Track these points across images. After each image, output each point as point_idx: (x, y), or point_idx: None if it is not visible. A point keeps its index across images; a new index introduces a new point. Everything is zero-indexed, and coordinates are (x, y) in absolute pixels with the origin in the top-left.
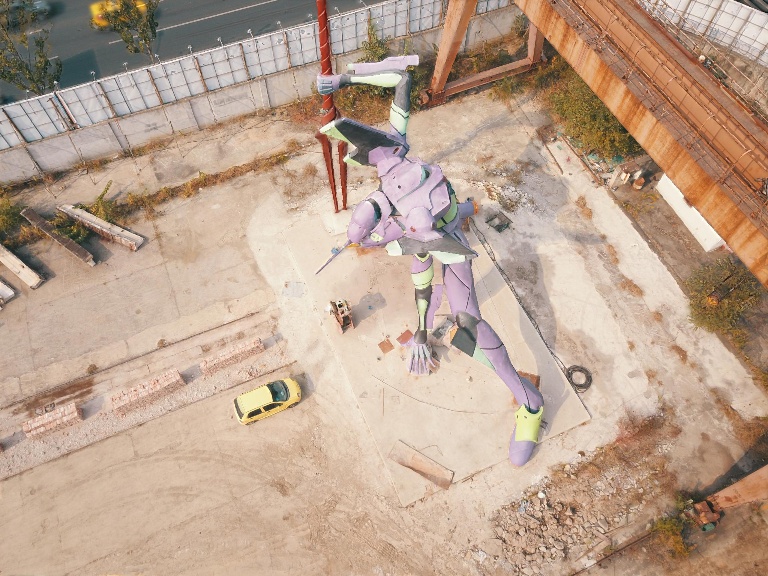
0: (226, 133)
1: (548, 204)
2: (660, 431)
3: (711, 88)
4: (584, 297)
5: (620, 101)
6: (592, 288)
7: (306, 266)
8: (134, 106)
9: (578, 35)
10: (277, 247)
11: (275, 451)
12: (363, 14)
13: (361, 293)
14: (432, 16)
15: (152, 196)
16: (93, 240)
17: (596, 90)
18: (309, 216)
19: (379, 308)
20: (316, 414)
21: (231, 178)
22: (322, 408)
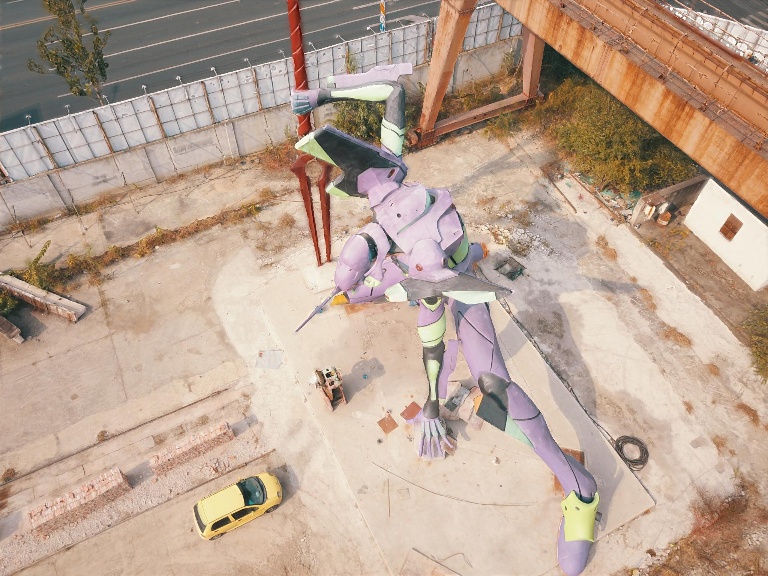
0: (188, 185)
1: (564, 246)
2: (744, 516)
3: (765, 85)
4: (622, 351)
5: (657, 106)
6: (630, 339)
7: (284, 330)
8: (79, 155)
9: (597, 37)
10: (249, 309)
11: (249, 574)
12: (340, 49)
13: (353, 359)
14: (416, 53)
15: (98, 257)
16: (23, 312)
17: (624, 98)
18: (287, 272)
19: (376, 377)
20: (302, 519)
21: (194, 233)
22: (310, 510)
